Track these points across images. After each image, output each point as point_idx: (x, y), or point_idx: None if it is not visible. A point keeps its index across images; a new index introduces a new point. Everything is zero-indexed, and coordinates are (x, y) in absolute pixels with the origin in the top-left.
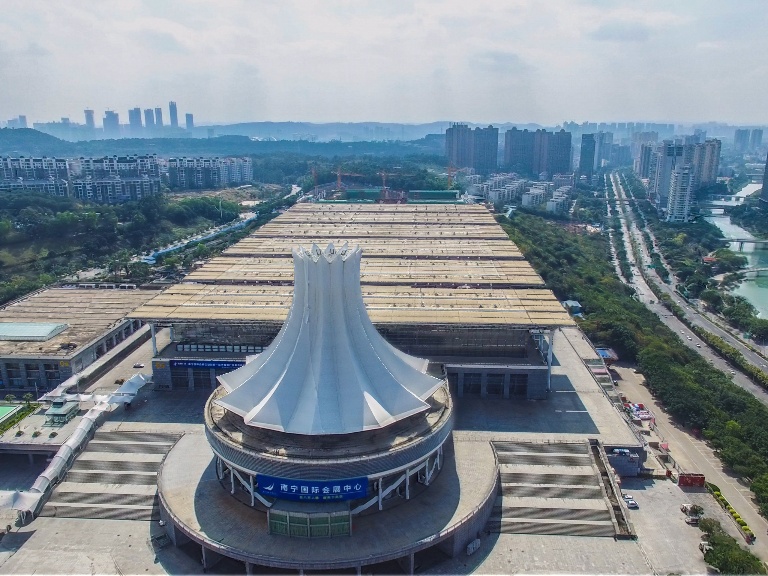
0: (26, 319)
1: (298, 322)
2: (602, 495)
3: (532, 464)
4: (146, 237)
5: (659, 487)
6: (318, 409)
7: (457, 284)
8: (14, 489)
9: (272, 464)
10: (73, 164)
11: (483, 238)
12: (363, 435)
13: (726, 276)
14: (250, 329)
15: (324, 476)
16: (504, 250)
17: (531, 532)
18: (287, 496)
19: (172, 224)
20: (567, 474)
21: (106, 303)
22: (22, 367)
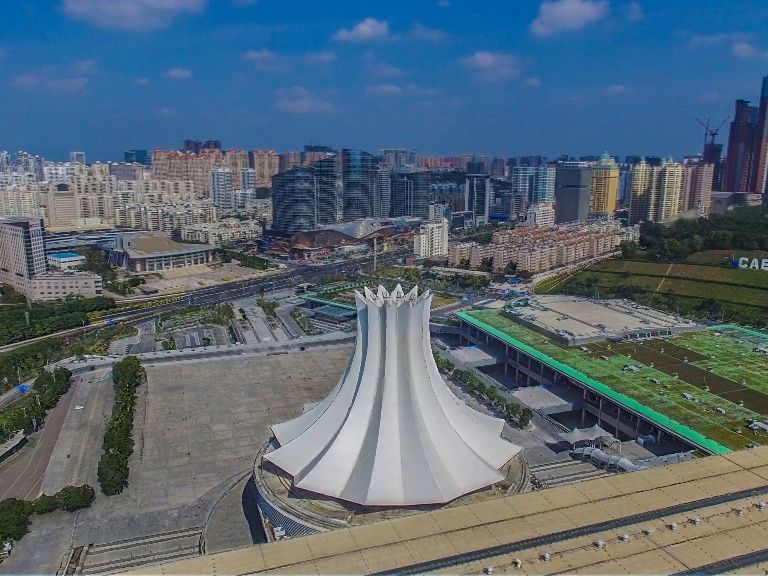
0: None
1: None
2: None
3: None
4: None
5: None
6: None
7: None
8: None
9: None
10: None
11: None
12: None
13: None
14: None
15: None
16: None
17: (176, 531)
18: None
19: None
20: (117, 569)
21: None
22: None
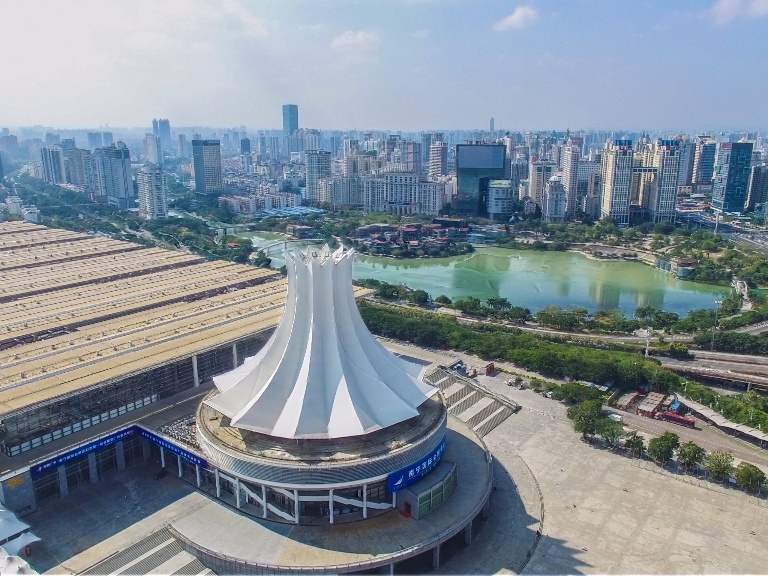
0: None
1: (319, 330)
2: (483, 394)
3: None
4: None
5: (482, 380)
6: (397, 395)
7: (219, 289)
8: None
9: (402, 456)
10: None
11: (121, 250)
12: None
13: (259, 255)
14: (111, 388)
15: (433, 446)
16: (176, 256)
17: (486, 433)
18: (414, 480)
19: None
20: (456, 392)
21: None
22: None
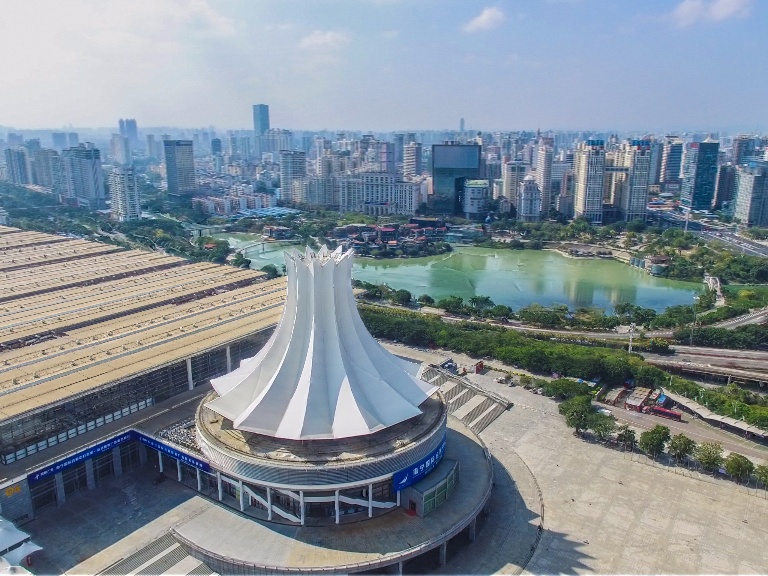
0: None
1: (320, 331)
2: (475, 392)
3: None
4: None
5: (473, 378)
6: (399, 394)
7: (207, 291)
8: None
9: (407, 455)
10: None
11: (101, 253)
12: None
13: (237, 256)
14: (106, 393)
15: (435, 444)
16: (158, 258)
17: (481, 430)
18: (418, 478)
19: None
20: (449, 390)
21: None
22: None
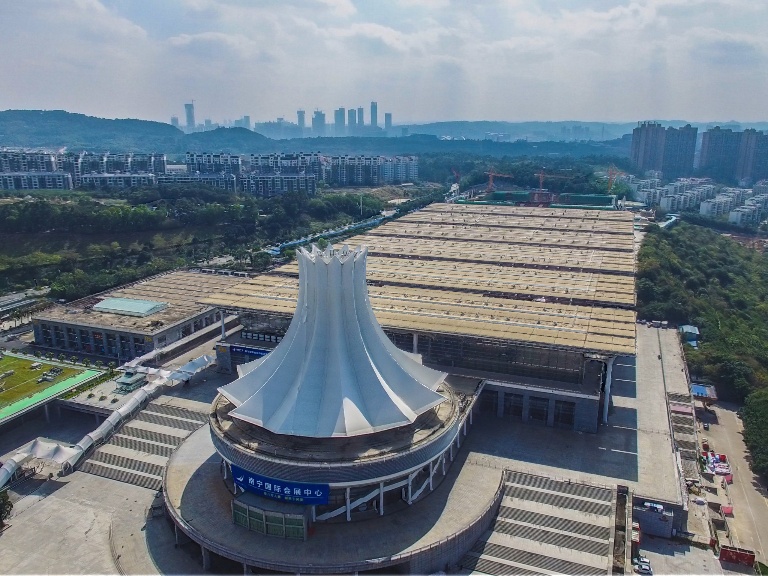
0: (142, 296)
1: None
2: (608, 552)
3: (541, 502)
4: (283, 229)
5: (692, 556)
6: (294, 409)
7: (534, 296)
8: (74, 443)
9: (242, 456)
10: (245, 160)
11: (603, 248)
12: (336, 441)
13: None
14: None
15: (286, 476)
16: (616, 263)
17: None
18: (254, 490)
19: (311, 218)
20: (575, 520)
21: (212, 288)
22: (118, 338)
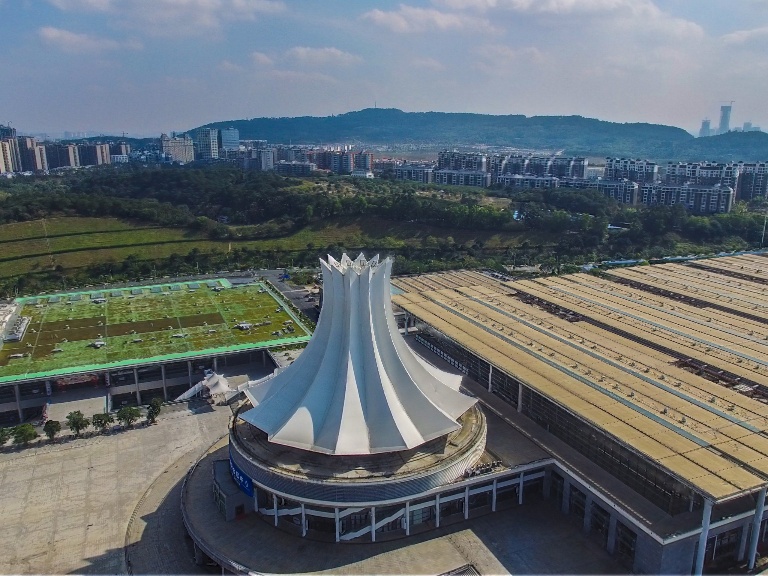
0: (408, 286)
1: None
2: None
3: None
4: (633, 246)
5: None
6: (268, 401)
7: (745, 380)
8: None
9: None
10: (662, 168)
11: None
12: None
13: None
14: None
15: None
16: None
17: None
18: None
19: (682, 238)
20: None
21: None
22: None
